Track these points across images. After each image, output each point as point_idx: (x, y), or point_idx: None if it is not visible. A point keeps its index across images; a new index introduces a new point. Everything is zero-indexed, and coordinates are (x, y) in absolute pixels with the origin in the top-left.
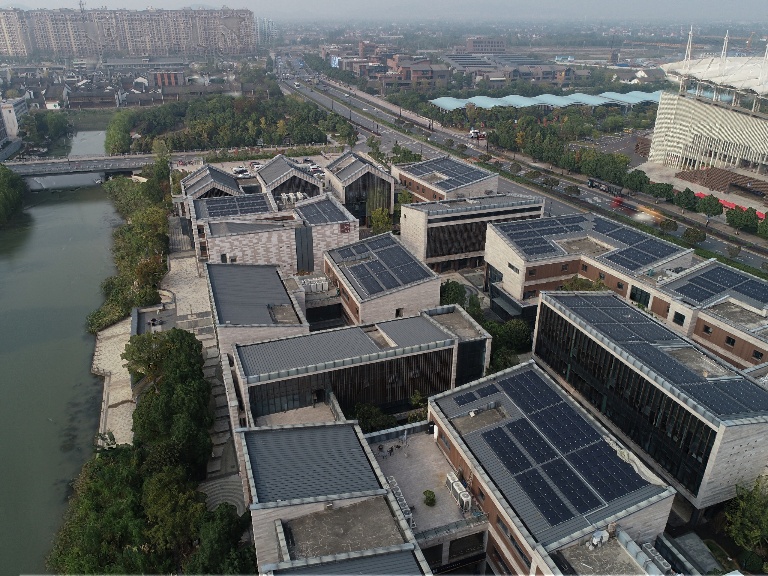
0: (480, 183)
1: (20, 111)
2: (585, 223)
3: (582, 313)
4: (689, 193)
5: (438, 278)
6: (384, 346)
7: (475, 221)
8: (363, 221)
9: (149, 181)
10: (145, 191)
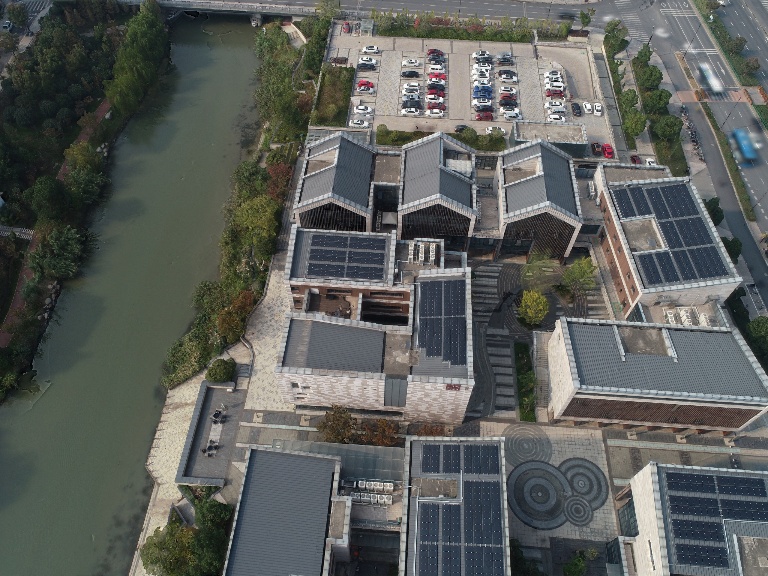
0: (704, 287)
1: None
2: None
3: None
4: None
5: None
6: None
7: (650, 401)
8: (524, 252)
9: (285, 100)
10: (279, 114)
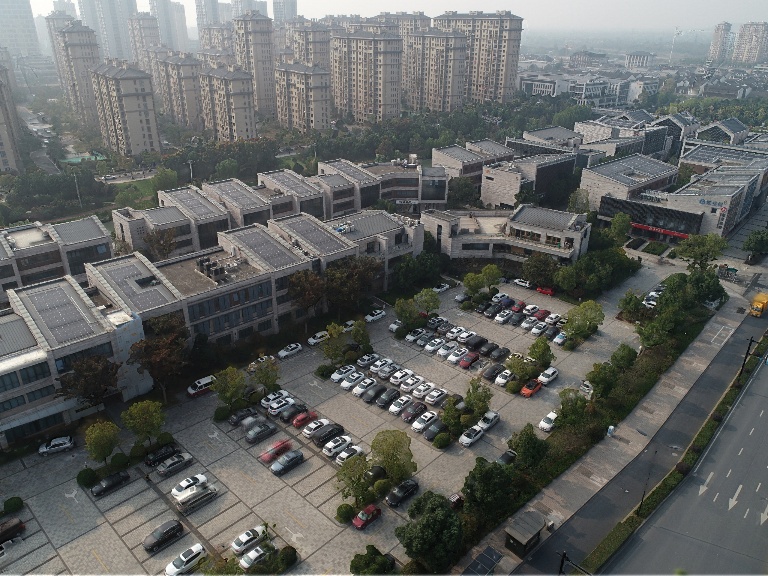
0: None
1: (649, 88)
2: (760, 159)
3: (634, 159)
4: None
5: (615, 144)
6: None
7: None
8: None
9: None
10: None
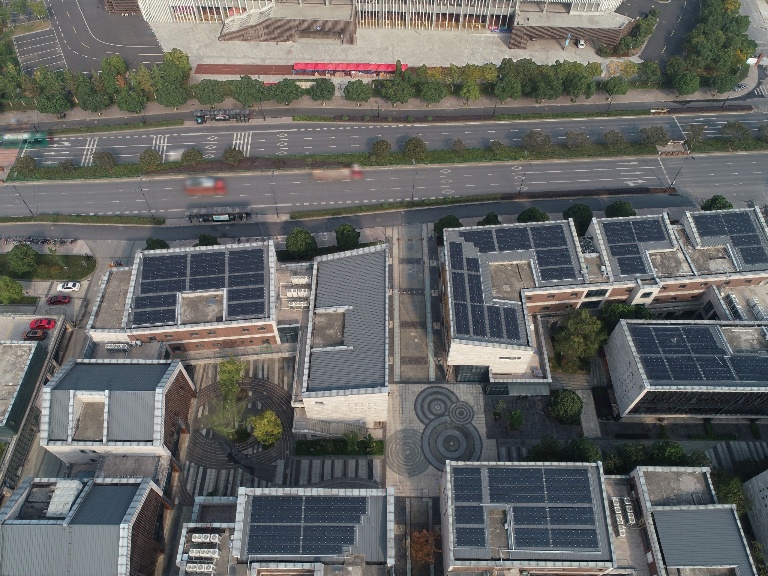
0: None
1: None
2: (466, 250)
3: (683, 375)
4: (325, 84)
5: None
6: (713, 574)
7: None
8: None
9: None
10: None
